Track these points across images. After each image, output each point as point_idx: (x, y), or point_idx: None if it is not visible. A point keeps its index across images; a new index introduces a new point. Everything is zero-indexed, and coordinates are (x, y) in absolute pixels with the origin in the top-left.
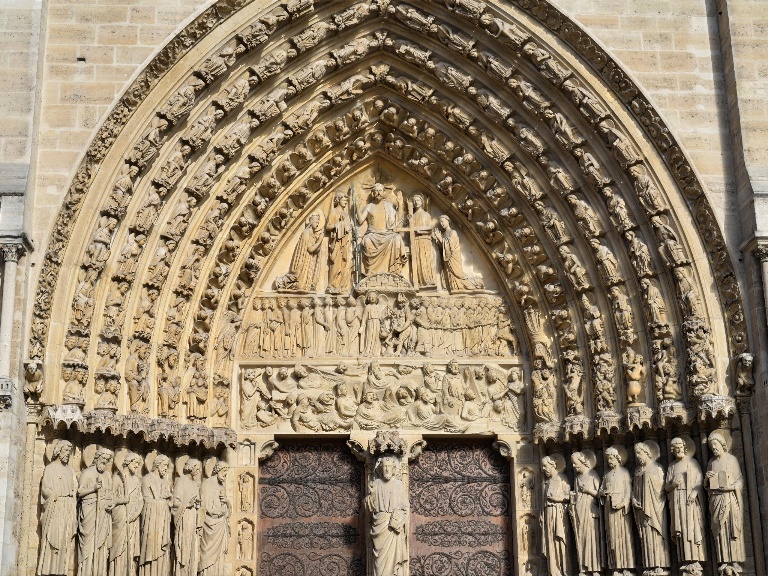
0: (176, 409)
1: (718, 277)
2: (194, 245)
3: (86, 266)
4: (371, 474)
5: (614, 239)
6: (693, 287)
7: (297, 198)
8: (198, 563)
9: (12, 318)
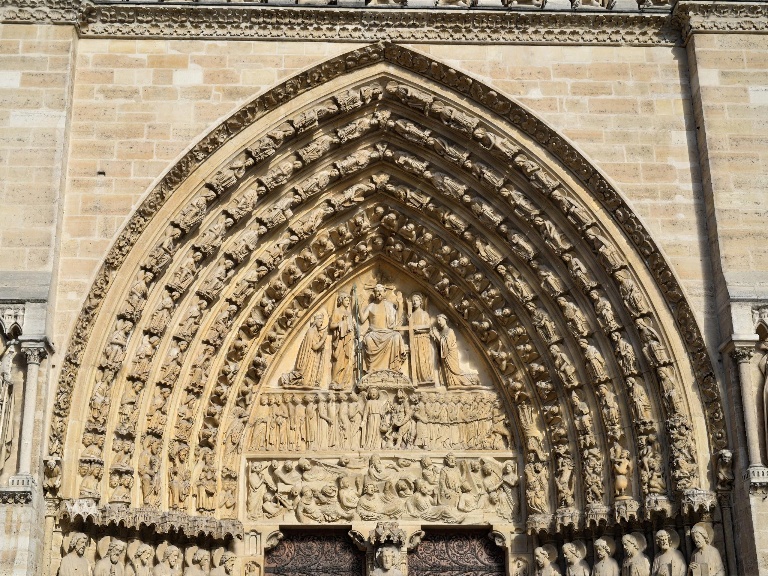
0: (186, 502)
1: (699, 376)
2: (205, 345)
3: (103, 367)
4: (372, 563)
5: (601, 339)
6: (675, 386)
7: (302, 299)
8: None
9: (33, 417)
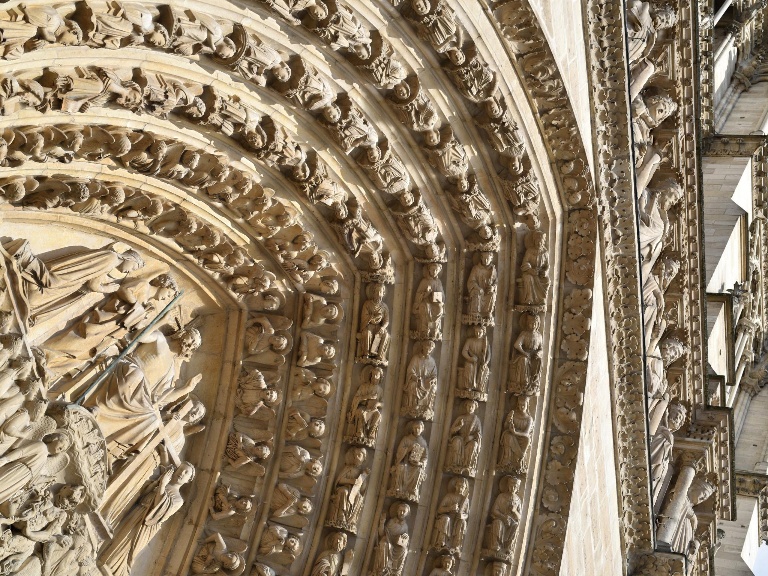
0: None
1: None
2: (131, 75)
3: None
4: None
5: None
6: None
7: (171, 217)
8: None
9: None
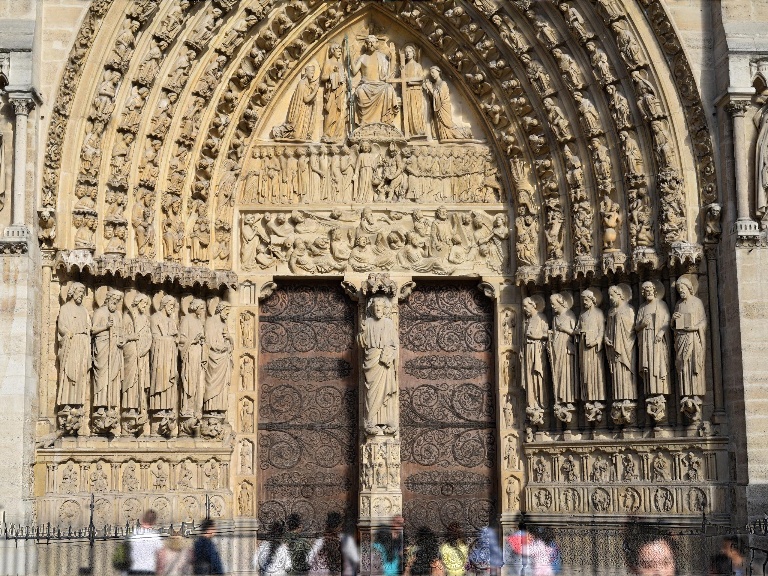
0: (180, 253)
1: (692, 130)
2: (194, 97)
3: (92, 118)
4: (364, 313)
5: (596, 92)
6: (668, 140)
7: (293, 50)
8: (204, 394)
9: (25, 169)
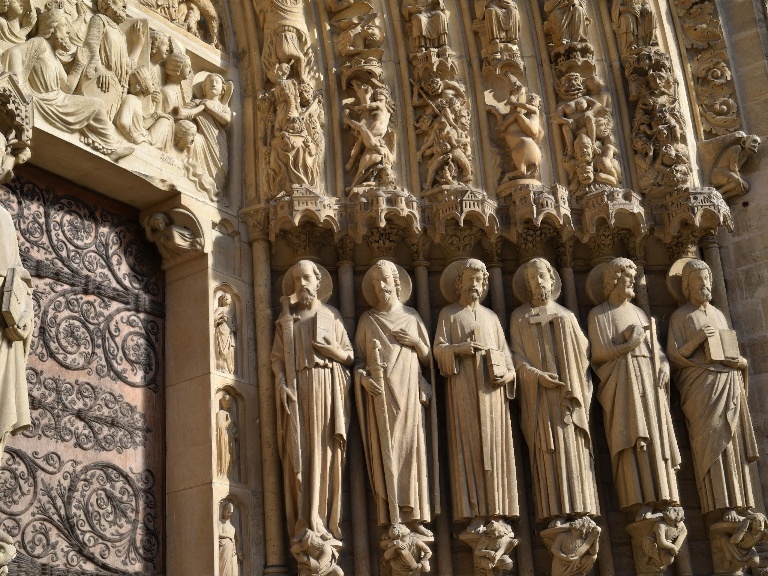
0: None
1: (679, 1)
2: None
3: None
4: None
5: None
6: None
7: None
8: None
9: None
